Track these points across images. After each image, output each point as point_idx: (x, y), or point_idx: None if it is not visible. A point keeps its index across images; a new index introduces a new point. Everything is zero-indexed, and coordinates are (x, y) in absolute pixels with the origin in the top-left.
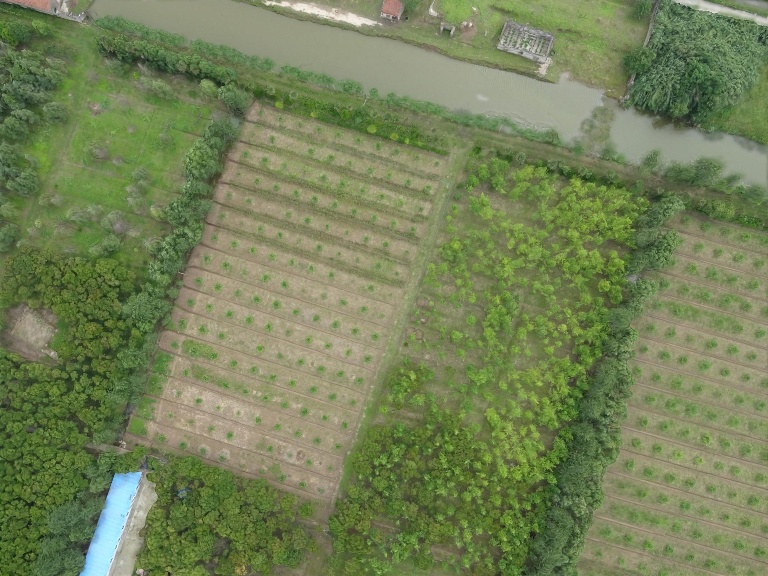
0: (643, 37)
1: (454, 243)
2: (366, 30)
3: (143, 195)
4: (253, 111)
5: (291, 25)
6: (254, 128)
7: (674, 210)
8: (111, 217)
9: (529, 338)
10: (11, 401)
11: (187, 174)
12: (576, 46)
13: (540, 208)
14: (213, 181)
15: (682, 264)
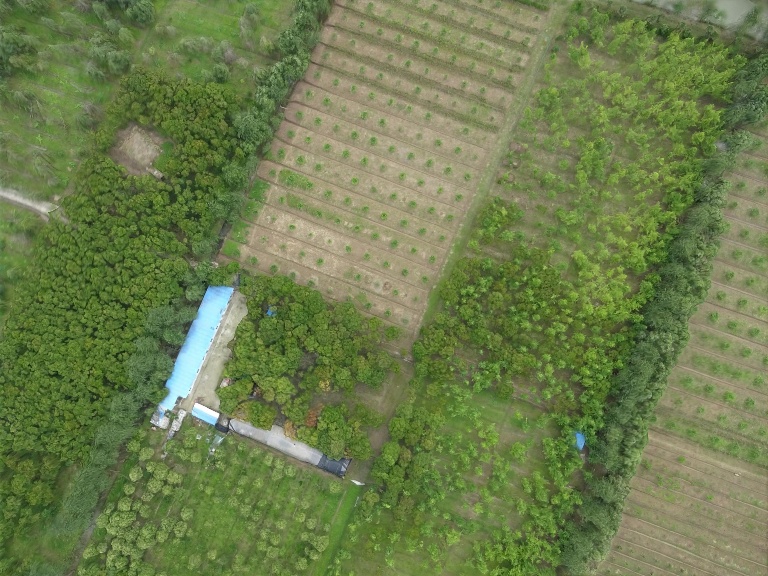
0: None
1: (551, 88)
2: None
3: (253, 30)
4: None
5: None
6: None
7: None
8: (224, 43)
9: (618, 188)
10: (117, 208)
11: (298, 8)
12: None
13: (638, 60)
14: (321, 20)
15: None
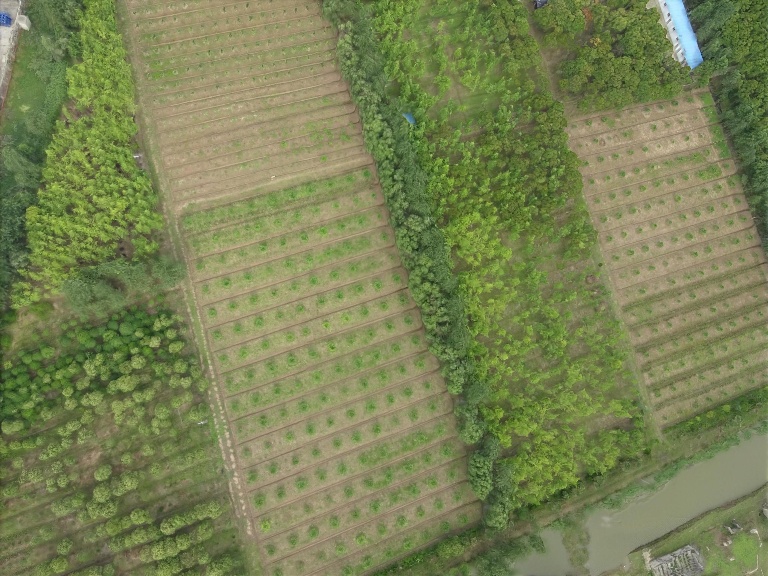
0: None
1: None
2: None
3: None
4: None
5: None
6: None
7: (499, 513)
8: None
9: (514, 333)
10: None
11: None
12: None
13: None
14: None
15: (441, 480)
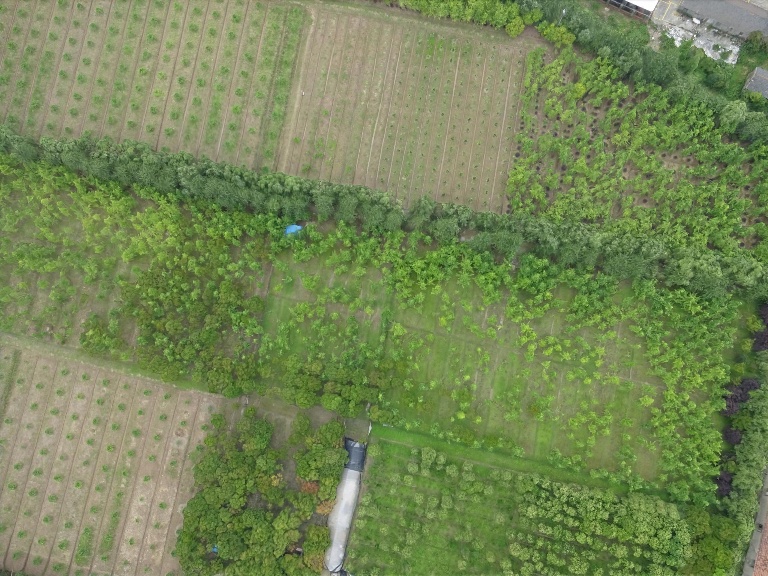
0: None
1: None
2: None
3: None
4: None
5: None
6: None
7: None
8: None
9: None
10: None
11: None
12: None
13: None
14: None
15: None
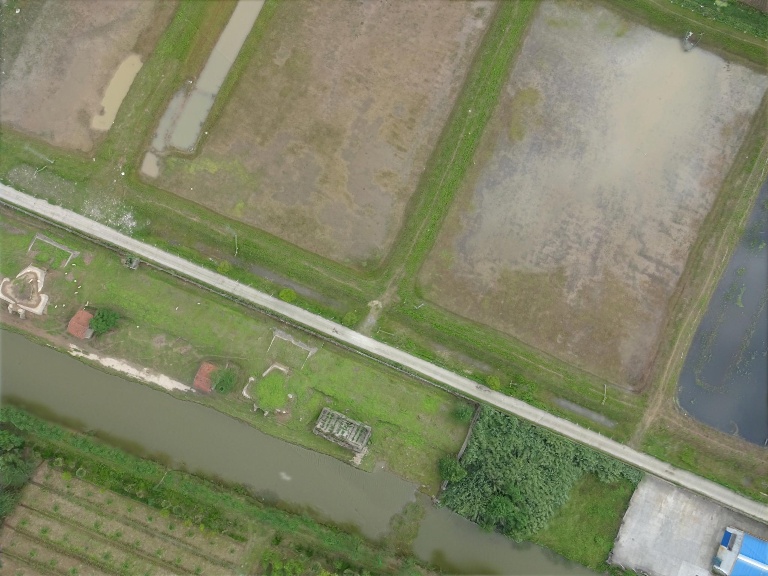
0: (462, 440)
1: None
2: (177, 395)
3: None
4: (40, 472)
5: (98, 378)
6: (38, 492)
7: None
8: None
9: None
10: None
11: None
12: (395, 438)
13: None
14: None
15: None
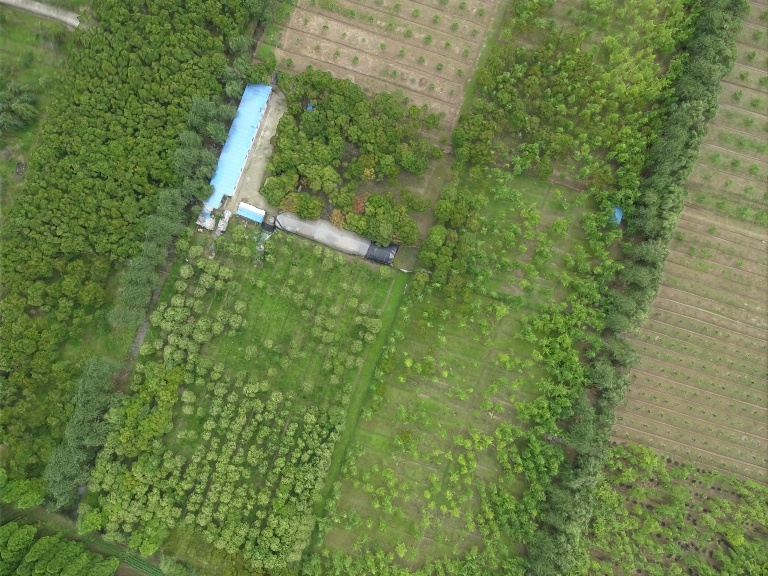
0: None
1: None
2: None
3: None
4: None
5: None
6: None
7: None
8: None
9: None
10: (149, 7)
11: None
12: None
13: None
14: None
15: None
